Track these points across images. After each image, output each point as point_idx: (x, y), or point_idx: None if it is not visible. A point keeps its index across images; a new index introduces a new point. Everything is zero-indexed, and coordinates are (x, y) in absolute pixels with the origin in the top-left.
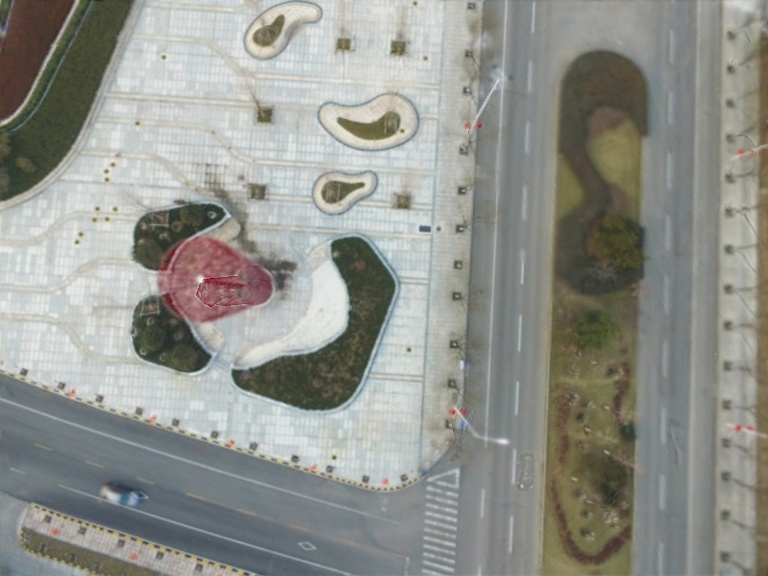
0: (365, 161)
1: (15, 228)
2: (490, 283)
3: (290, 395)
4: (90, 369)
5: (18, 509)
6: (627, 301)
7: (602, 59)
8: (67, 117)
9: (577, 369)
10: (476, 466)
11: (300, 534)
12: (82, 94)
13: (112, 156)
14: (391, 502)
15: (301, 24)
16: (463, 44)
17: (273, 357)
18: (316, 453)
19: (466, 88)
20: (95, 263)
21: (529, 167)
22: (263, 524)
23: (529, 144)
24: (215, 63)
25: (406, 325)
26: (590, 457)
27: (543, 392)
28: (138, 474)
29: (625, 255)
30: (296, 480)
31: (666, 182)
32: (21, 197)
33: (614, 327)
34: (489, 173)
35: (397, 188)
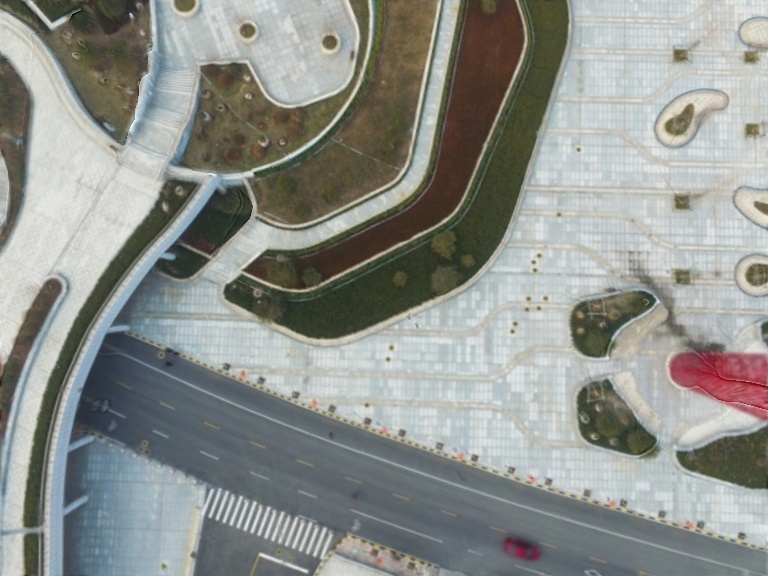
0: None
1: (453, 320)
2: None
3: (735, 475)
4: (537, 454)
5: None
6: None
7: None
8: (497, 212)
9: None
10: None
11: None
12: (510, 190)
13: (538, 247)
14: None
15: (709, 111)
16: None
17: (715, 438)
18: (762, 530)
19: None
20: (532, 351)
21: None
22: None
23: None
24: (628, 153)
25: None
26: None
27: None
28: (590, 554)
29: None
30: (744, 557)
31: None
32: (457, 290)
33: None
34: None
35: None
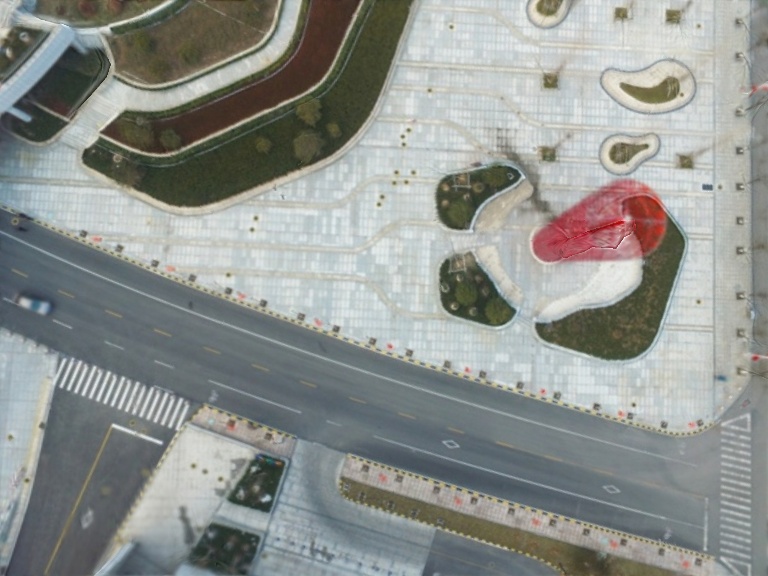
0: (647, 124)
1: (319, 192)
2: None
3: (592, 346)
4: (399, 325)
5: (336, 460)
6: None
7: None
8: (367, 84)
9: None
10: (766, 411)
11: (604, 478)
12: (380, 62)
13: (407, 122)
14: (689, 446)
15: None
16: (733, 12)
17: (573, 310)
18: (617, 401)
19: (738, 54)
20: (397, 224)
21: None
22: (570, 469)
23: None
24: (500, 32)
25: (695, 279)
26: None
27: None
28: (449, 424)
29: None
30: (598, 427)
31: None
32: (324, 162)
33: None
34: (763, 134)
35: (679, 149)
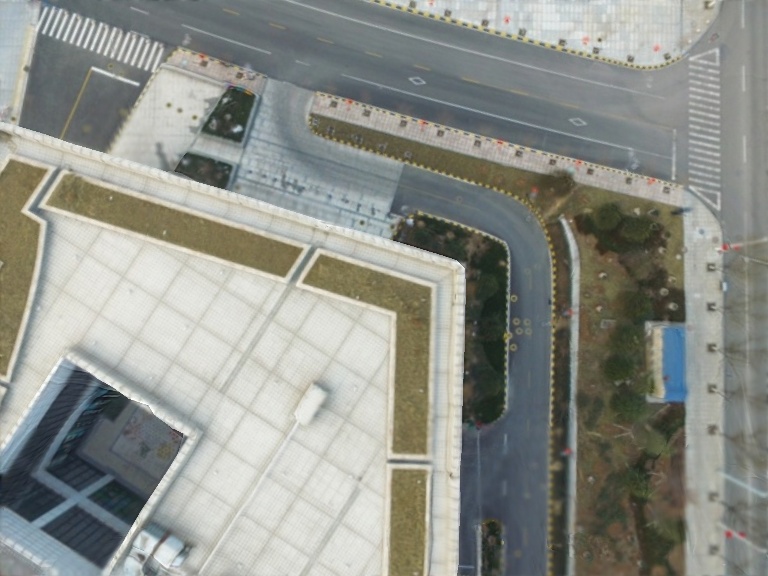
0: None
1: None
2: None
3: None
4: None
5: (305, 98)
6: None
7: None
8: None
9: None
10: (735, 45)
11: (571, 111)
12: None
13: None
14: (656, 79)
15: None
16: None
17: None
18: (582, 36)
19: None
20: None
21: None
22: (535, 103)
23: None
24: None
25: None
26: None
27: None
28: (415, 62)
29: None
30: (564, 63)
31: None
32: None
33: None
34: None
35: None
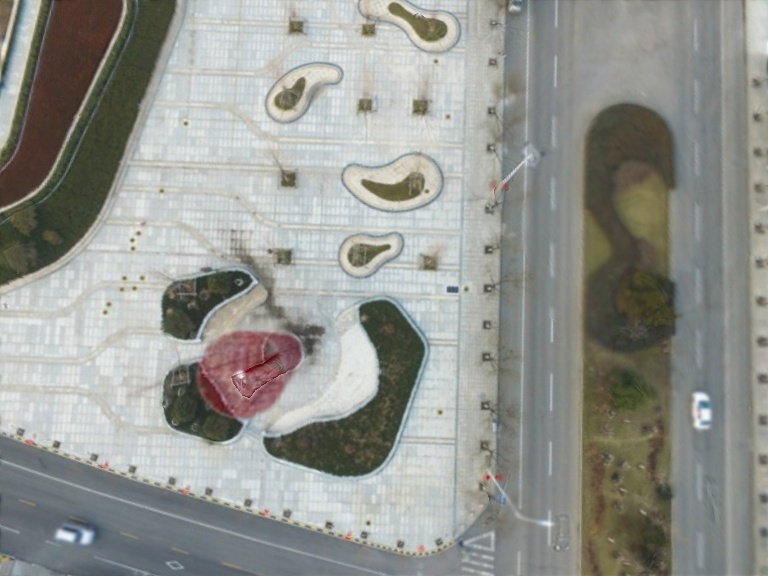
0: (390, 222)
1: (43, 300)
2: (520, 342)
3: (322, 462)
4: (122, 440)
5: None
6: (659, 357)
7: (626, 112)
8: (92, 187)
9: (610, 429)
10: (511, 528)
11: None
12: (106, 164)
13: (137, 225)
14: (427, 567)
15: (322, 86)
16: (485, 101)
17: (304, 424)
18: (350, 519)
19: (490, 145)
20: (124, 333)
21: (555, 223)
22: None
23: (555, 200)
24: (237, 128)
25: (436, 387)
26: (626, 518)
27: (576, 452)
28: (173, 544)
29: (656, 313)
30: (331, 547)
31: (694, 234)
32: (48, 269)
33: (647, 385)
34: (515, 231)
35: (423, 249)
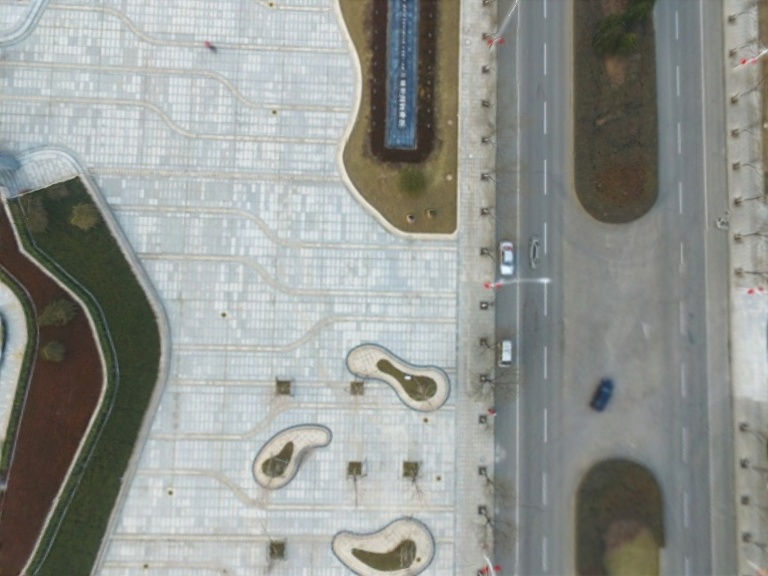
0: None
1: None
2: None
3: None
4: None
5: None
6: None
7: (616, 470)
8: (73, 570)
9: None
10: None
11: None
12: (87, 544)
13: None
14: None
15: (310, 449)
16: (476, 461)
17: None
18: None
19: (481, 508)
20: None
21: None
22: None
23: (547, 562)
24: (224, 496)
25: None
26: None
27: None
28: None
29: None
30: None
31: None
32: None
33: None
34: None
35: None
